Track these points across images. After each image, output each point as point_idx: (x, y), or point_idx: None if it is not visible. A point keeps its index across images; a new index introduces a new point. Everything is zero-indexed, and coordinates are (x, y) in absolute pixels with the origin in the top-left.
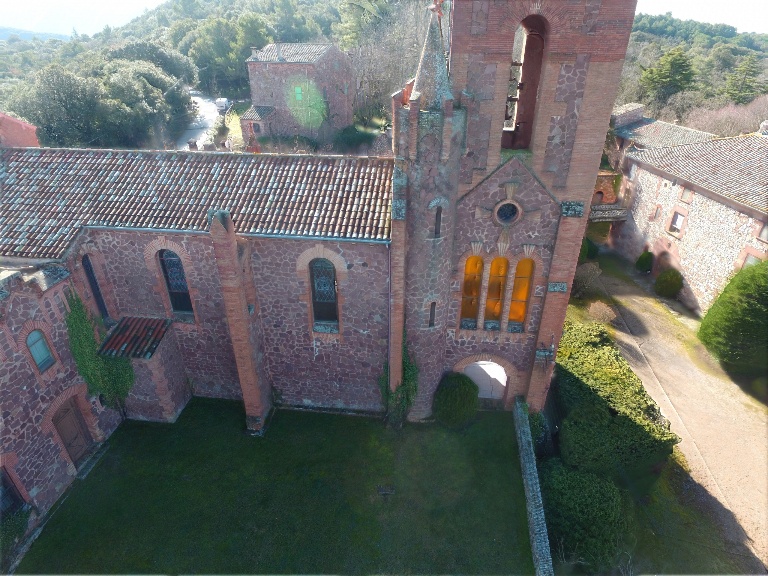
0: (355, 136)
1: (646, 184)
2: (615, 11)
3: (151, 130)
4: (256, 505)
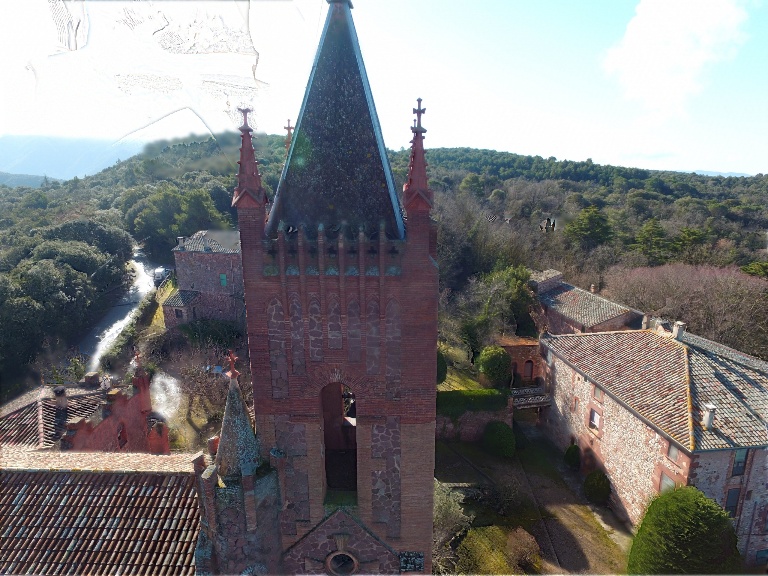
0: None
1: (562, 373)
2: (416, 381)
3: (45, 343)
4: None
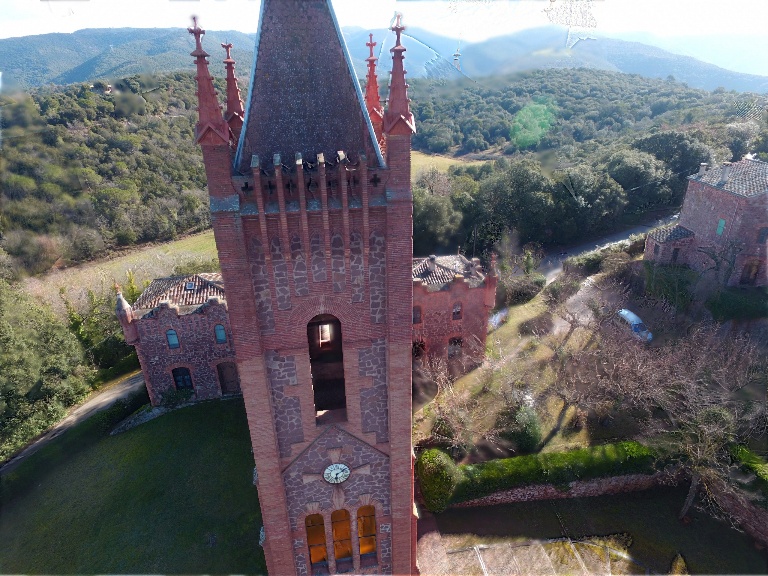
0: (752, 304)
1: None
2: None
3: (506, 230)
4: (203, 474)
